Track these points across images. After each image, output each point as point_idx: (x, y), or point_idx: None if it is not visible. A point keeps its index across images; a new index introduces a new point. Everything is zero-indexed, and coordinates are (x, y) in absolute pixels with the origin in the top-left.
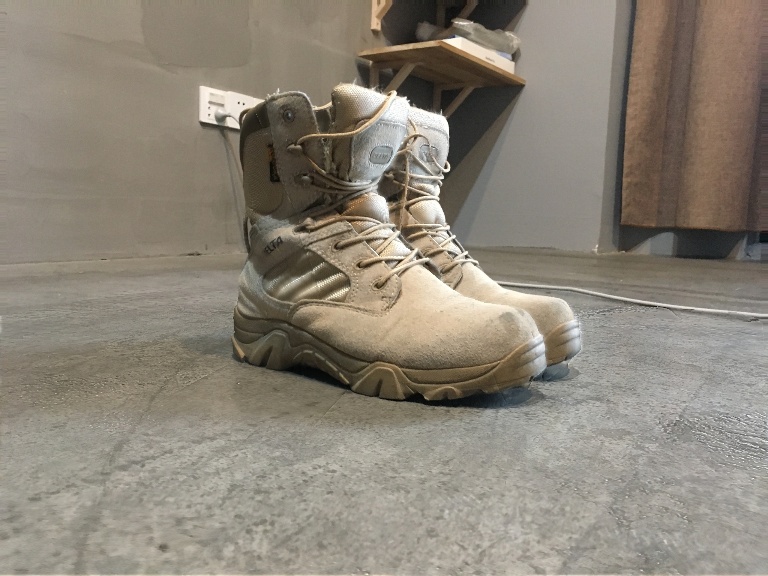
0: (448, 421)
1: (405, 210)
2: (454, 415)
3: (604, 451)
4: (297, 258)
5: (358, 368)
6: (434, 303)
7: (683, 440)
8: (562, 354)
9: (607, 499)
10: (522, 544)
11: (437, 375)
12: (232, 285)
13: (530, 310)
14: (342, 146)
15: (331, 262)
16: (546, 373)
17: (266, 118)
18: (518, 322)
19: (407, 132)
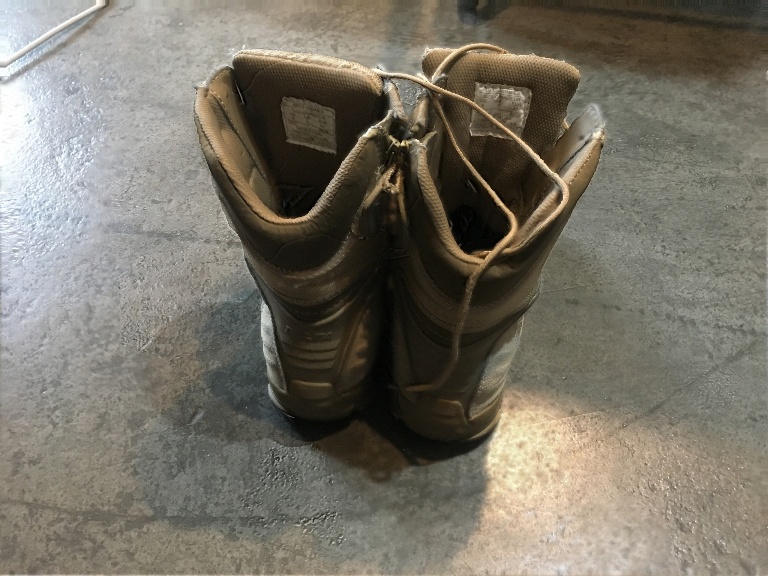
0: None
1: None
2: None
3: None
4: None
5: None
6: None
7: None
8: None
9: None
10: (663, 174)
11: None
12: None
13: None
14: None
15: None
16: None
17: None
18: None
19: None
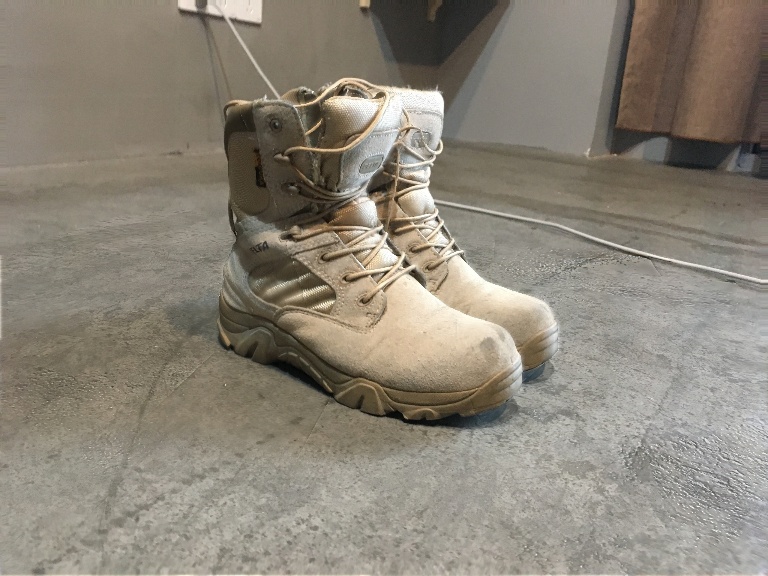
0: (425, 449)
1: (394, 202)
2: (431, 439)
3: (567, 497)
4: (283, 264)
5: (341, 380)
6: (418, 321)
7: (641, 479)
8: (539, 360)
9: (563, 570)
10: None
11: (417, 397)
12: (216, 211)
13: (512, 317)
14: (331, 161)
15: (317, 274)
16: (522, 376)
17: (252, 122)
18: (498, 350)
19: (400, 121)
